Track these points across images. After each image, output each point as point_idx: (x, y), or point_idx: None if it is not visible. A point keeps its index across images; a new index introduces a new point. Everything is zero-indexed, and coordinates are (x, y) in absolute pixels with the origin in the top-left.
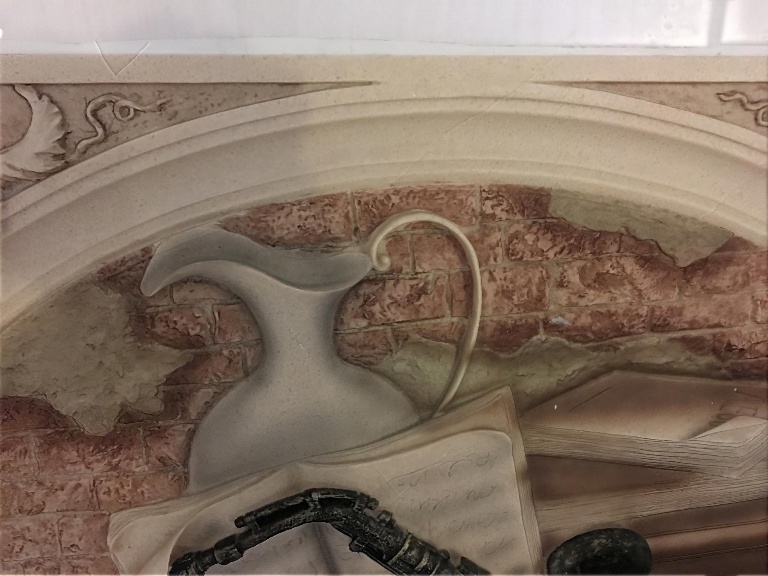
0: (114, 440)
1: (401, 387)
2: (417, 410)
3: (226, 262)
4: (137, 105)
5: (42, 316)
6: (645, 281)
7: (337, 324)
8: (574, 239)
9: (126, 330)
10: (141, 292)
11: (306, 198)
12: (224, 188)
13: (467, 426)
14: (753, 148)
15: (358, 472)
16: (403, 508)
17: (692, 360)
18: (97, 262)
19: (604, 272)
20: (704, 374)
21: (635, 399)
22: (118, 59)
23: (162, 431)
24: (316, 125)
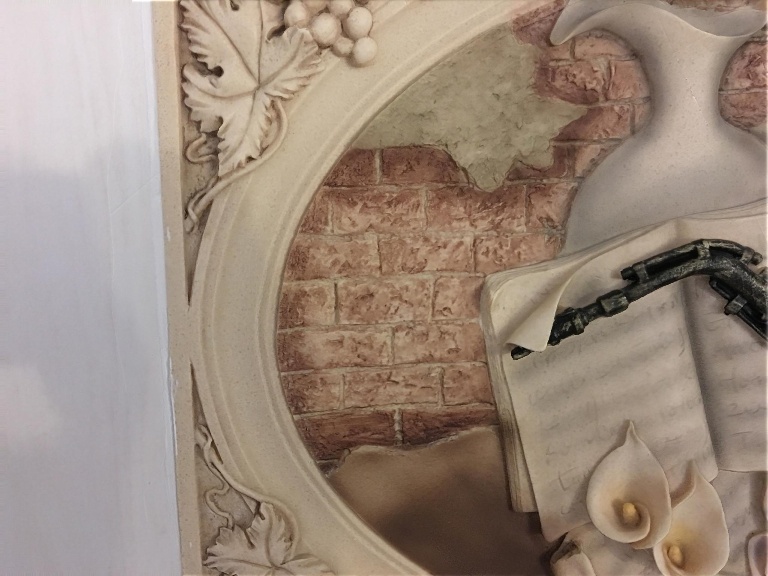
0: (500, 197)
1: None
2: None
3: (643, 4)
4: None
5: (459, 62)
6: None
7: (722, 84)
8: None
9: (530, 81)
10: (548, 44)
11: None
12: None
13: None
14: None
15: (741, 227)
16: None
17: None
18: (513, 12)
19: None
20: None
21: None
22: None
23: (547, 188)
24: None
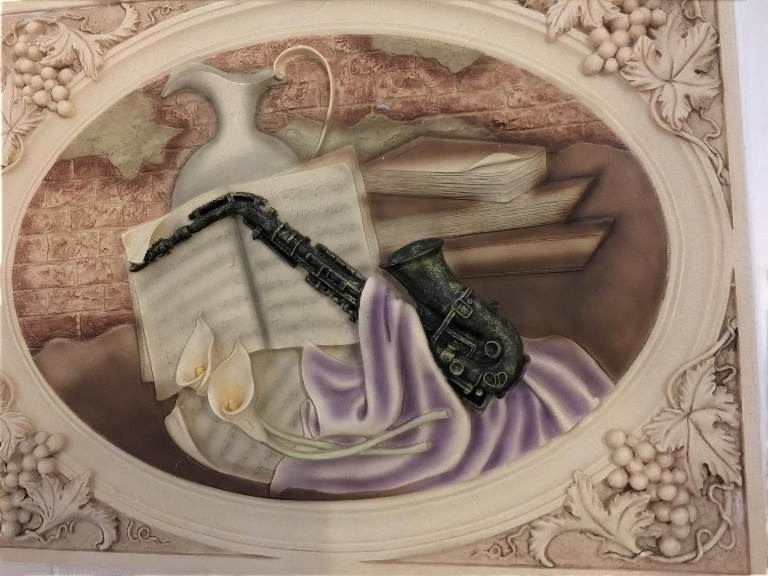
0: (137, 182)
1: (291, 147)
2: (300, 162)
3: (200, 71)
4: (171, 7)
5: (113, 110)
6: (433, 83)
7: (257, 111)
8: (388, 61)
9: (151, 118)
10: (161, 98)
11: (245, 47)
12: (206, 45)
13: None
14: (482, 3)
15: (259, 186)
16: (286, 214)
17: (469, 129)
18: (143, 84)
19: (407, 78)
20: (479, 138)
21: (433, 152)
22: None
23: (161, 175)
24: (250, 9)
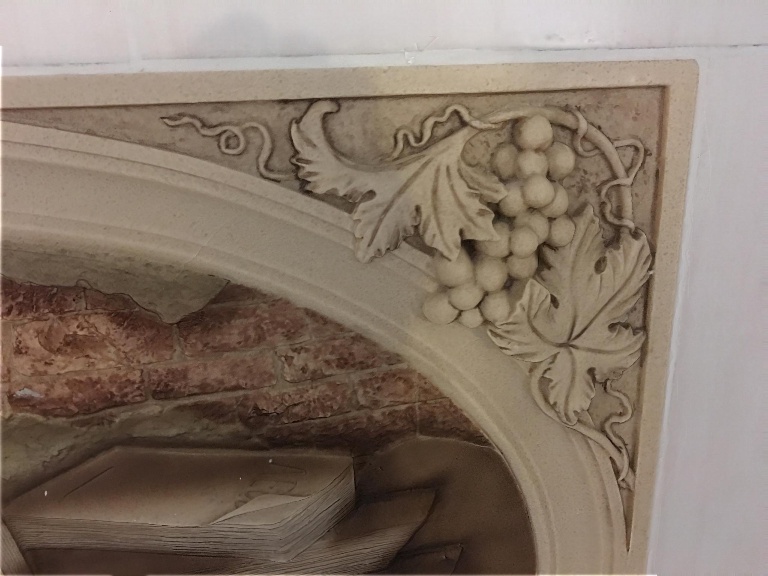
0: None
1: None
2: None
3: None
4: None
5: None
6: (128, 341)
7: None
8: (22, 297)
9: None
10: None
11: None
12: None
13: None
14: (216, 181)
15: None
16: None
17: (211, 429)
18: None
19: (71, 334)
20: (231, 444)
21: (144, 479)
22: None
23: None
24: None
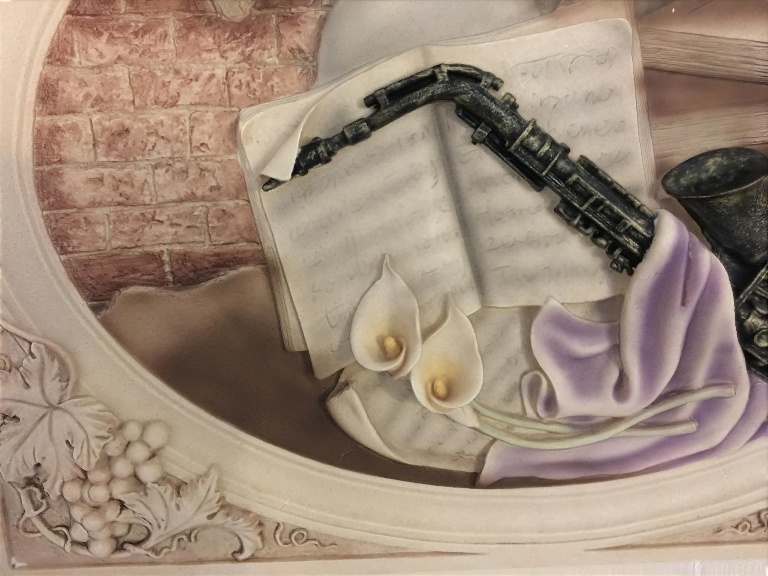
0: (249, 27)
1: None
2: (538, 7)
3: None
4: None
5: None
6: None
7: None
8: None
9: None
10: None
11: None
12: None
13: (588, 19)
14: None
15: (484, 53)
16: (524, 102)
17: None
18: None
19: None
20: None
21: (752, 4)
22: None
23: (295, 17)
24: None
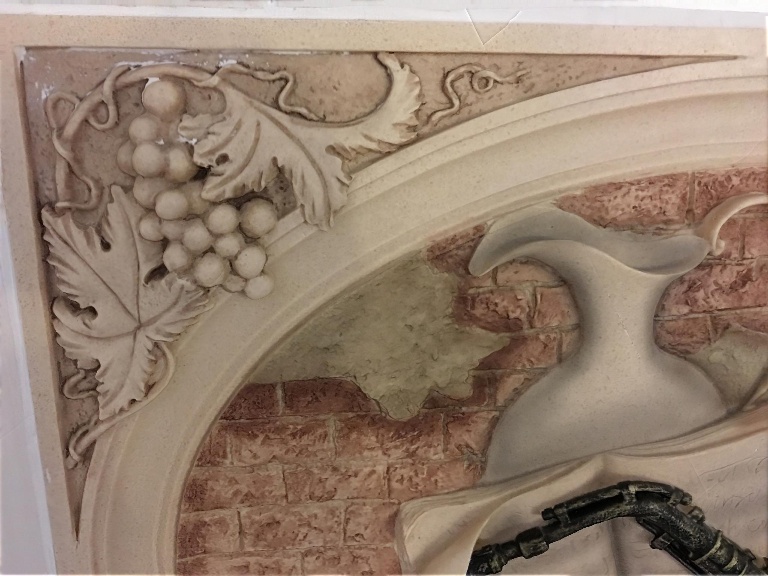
0: (415, 426)
1: (712, 378)
2: (725, 403)
3: (570, 242)
4: (498, 76)
5: (367, 294)
6: None
7: (658, 310)
8: None
9: (446, 311)
10: (466, 272)
11: (645, 178)
12: (565, 165)
13: None
14: None
15: (671, 465)
16: (707, 505)
17: None
18: (427, 240)
19: None
20: None
21: None
22: (489, 27)
23: (466, 418)
24: (672, 101)
